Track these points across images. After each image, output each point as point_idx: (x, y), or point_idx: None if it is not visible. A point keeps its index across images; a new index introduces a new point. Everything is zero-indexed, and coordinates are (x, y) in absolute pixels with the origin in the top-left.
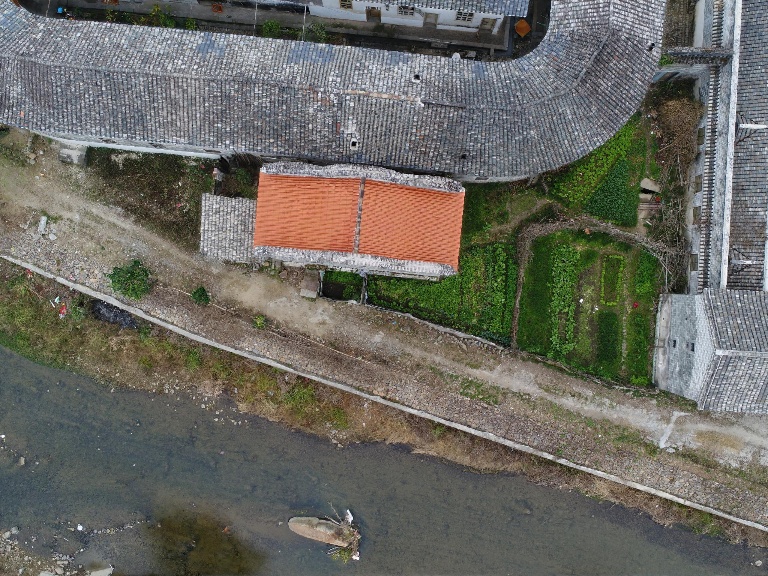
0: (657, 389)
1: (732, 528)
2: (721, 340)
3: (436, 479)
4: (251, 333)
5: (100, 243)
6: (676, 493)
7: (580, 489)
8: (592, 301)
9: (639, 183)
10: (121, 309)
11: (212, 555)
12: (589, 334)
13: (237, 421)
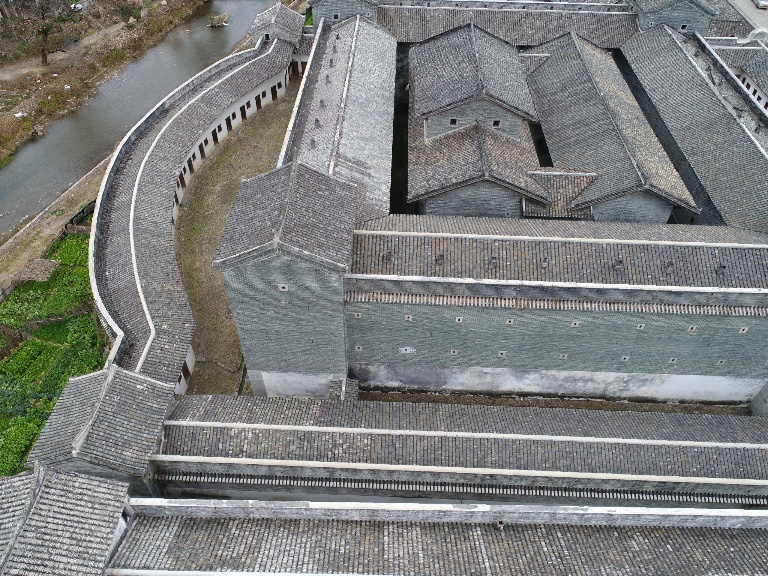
0: None
1: None
2: (285, 7)
3: None
4: None
5: None
6: None
7: None
8: None
9: None
10: None
11: (219, 5)
12: None
13: None
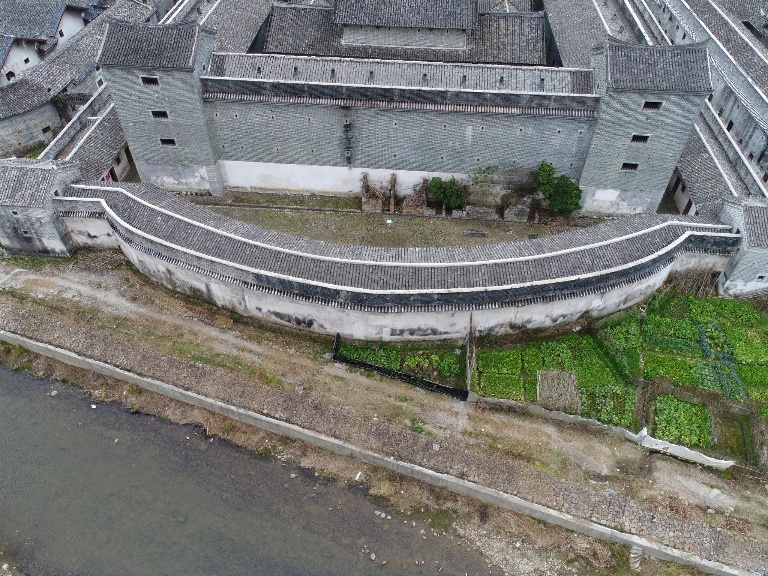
0: (2, 247)
1: (39, 361)
2: None
3: None
4: None
5: None
6: None
7: None
8: None
9: None
10: None
11: None
12: None
13: None
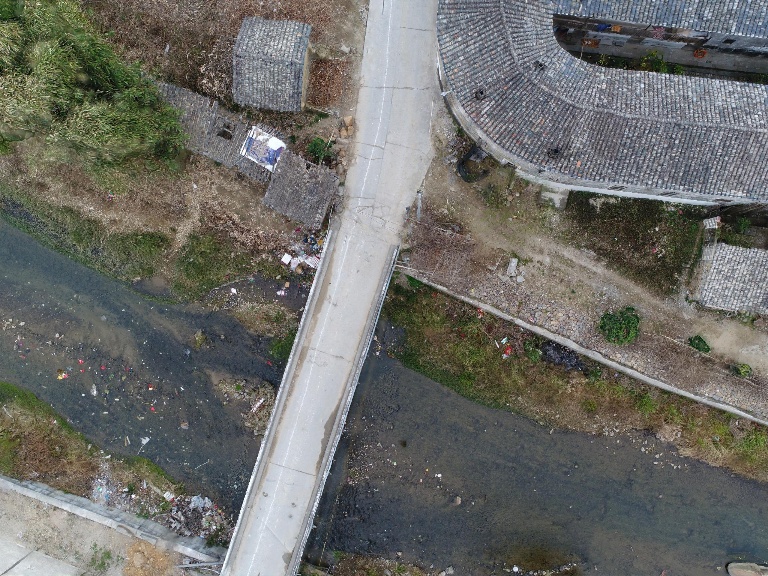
0: None
1: None
2: None
3: None
4: (718, 380)
5: (570, 286)
6: None
7: None
8: None
9: None
10: (569, 351)
11: None
12: None
13: (676, 465)
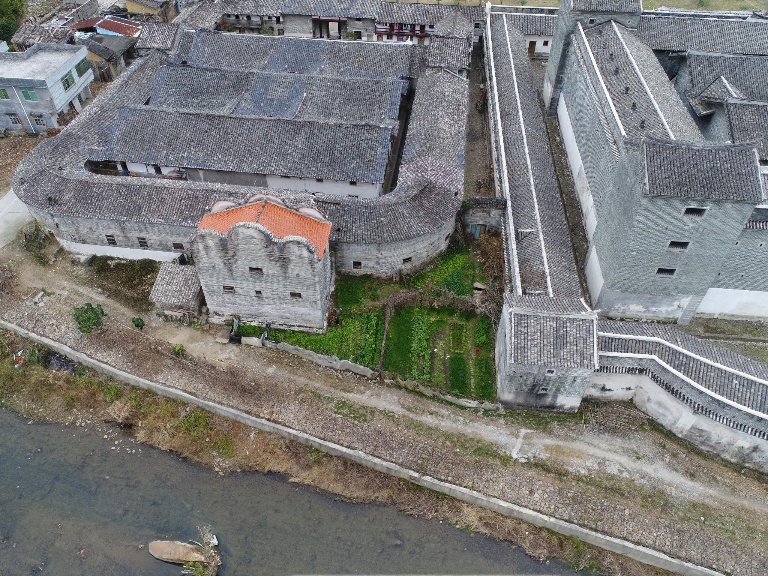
0: (499, 402)
1: (608, 559)
2: None
3: (308, 508)
4: (168, 366)
5: None
6: (539, 508)
7: (450, 519)
8: (444, 350)
9: (472, 284)
10: (68, 360)
11: None
12: (443, 371)
13: (132, 450)
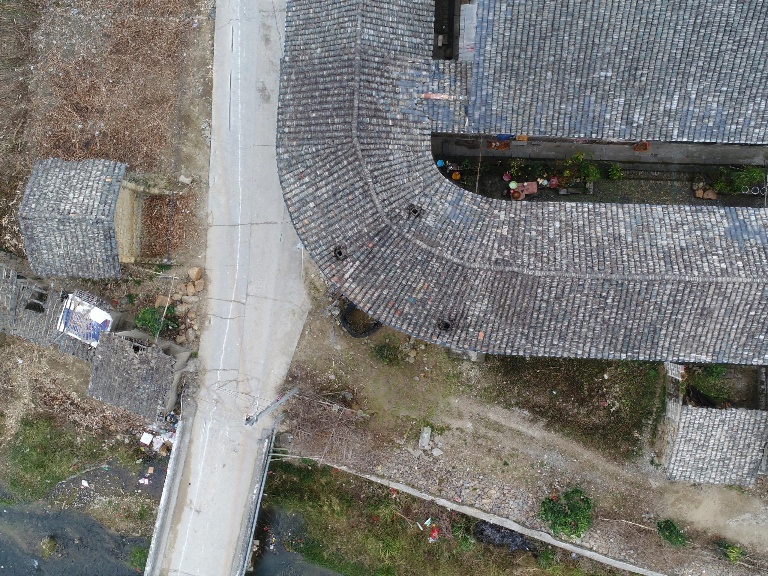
0: None
1: None
2: None
3: None
4: (702, 560)
5: (501, 457)
6: None
7: None
8: None
9: None
10: None
11: None
12: None
13: None
